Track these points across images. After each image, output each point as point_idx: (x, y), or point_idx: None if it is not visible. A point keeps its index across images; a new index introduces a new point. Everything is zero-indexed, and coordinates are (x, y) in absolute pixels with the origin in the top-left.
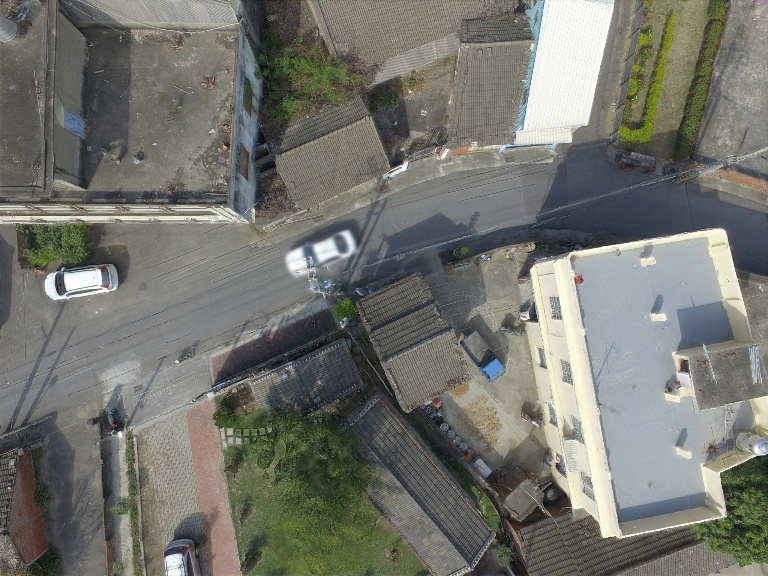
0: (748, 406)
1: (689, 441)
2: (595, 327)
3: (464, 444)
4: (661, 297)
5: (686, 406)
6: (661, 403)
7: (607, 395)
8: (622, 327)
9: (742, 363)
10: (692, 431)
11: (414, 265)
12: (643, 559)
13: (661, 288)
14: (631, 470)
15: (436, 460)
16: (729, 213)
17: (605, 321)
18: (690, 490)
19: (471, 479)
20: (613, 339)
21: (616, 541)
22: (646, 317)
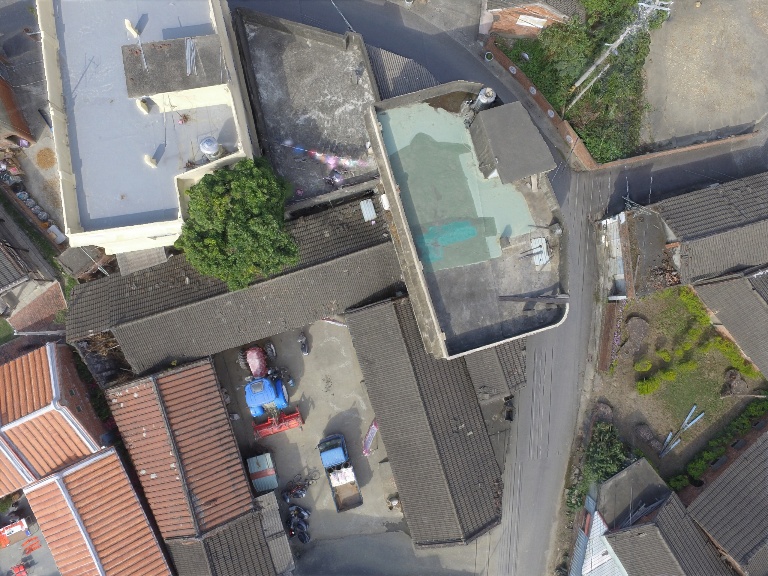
0: (232, 125)
1: (167, 156)
2: (75, 41)
3: (43, 213)
4: (146, 15)
5: (166, 122)
6: (139, 117)
7: (84, 108)
8: (103, 42)
9: (177, 54)
10: (171, 146)
11: (12, 43)
12: (175, 306)
13: (147, 7)
14: (104, 182)
15: (16, 229)
16: (340, 3)
17: (86, 36)
18: (165, 204)
19: (53, 250)
20: (93, 54)
21: (158, 293)
22: (129, 34)
